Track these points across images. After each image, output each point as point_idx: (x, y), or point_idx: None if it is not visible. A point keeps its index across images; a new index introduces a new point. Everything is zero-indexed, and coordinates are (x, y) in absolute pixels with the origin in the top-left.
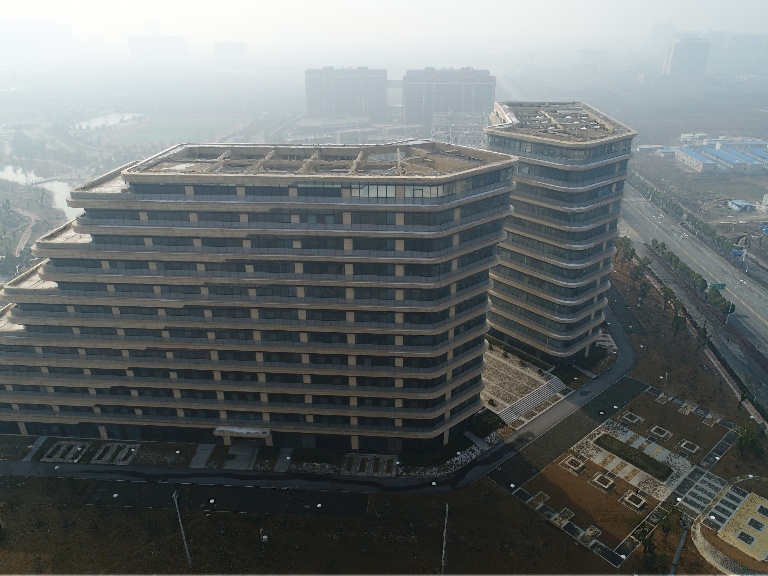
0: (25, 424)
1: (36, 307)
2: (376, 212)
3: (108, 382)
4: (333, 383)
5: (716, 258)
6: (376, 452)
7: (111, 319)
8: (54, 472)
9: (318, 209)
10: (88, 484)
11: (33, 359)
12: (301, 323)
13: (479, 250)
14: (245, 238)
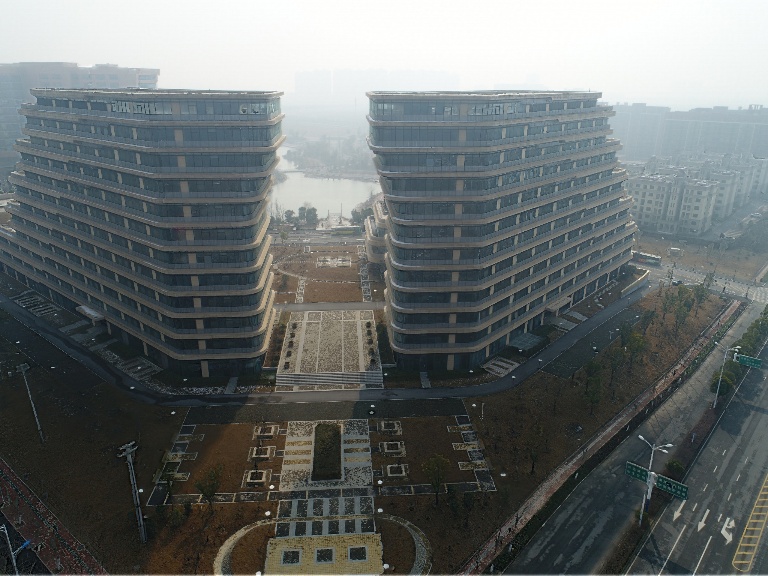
0: (27, 278)
1: (20, 189)
2: (124, 126)
3: (45, 253)
4: (128, 285)
5: None
6: (155, 362)
7: (41, 203)
8: (8, 307)
9: (98, 121)
10: (7, 318)
11: (21, 227)
12: (107, 224)
13: (219, 181)
14: (77, 144)
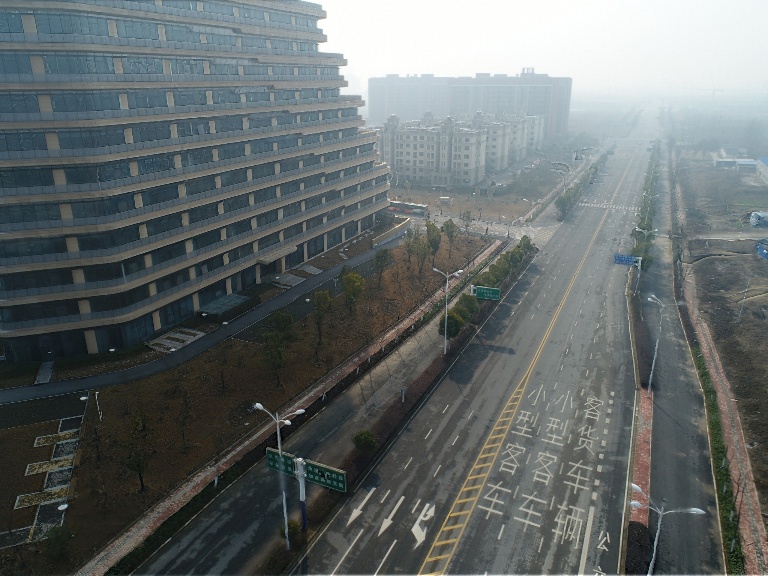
0: None
1: None
2: None
3: None
4: None
5: (619, 275)
6: None
7: None
8: None
9: None
10: None
11: None
12: None
13: None
14: None
